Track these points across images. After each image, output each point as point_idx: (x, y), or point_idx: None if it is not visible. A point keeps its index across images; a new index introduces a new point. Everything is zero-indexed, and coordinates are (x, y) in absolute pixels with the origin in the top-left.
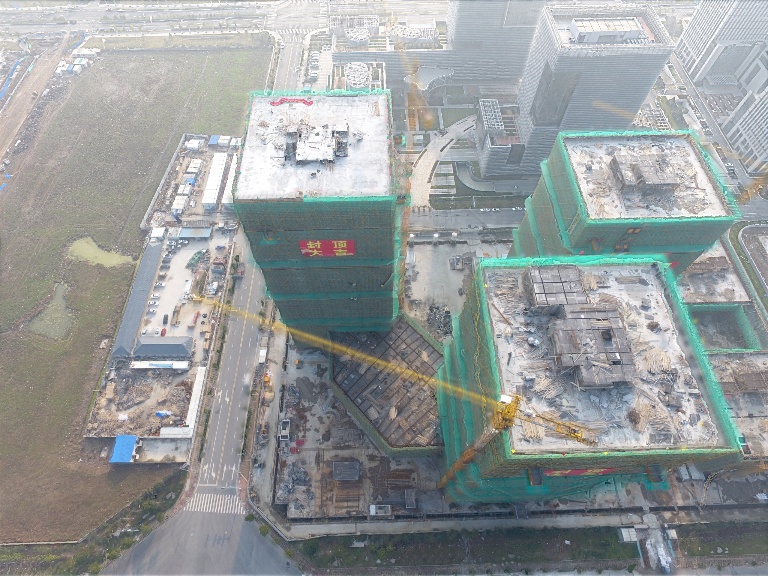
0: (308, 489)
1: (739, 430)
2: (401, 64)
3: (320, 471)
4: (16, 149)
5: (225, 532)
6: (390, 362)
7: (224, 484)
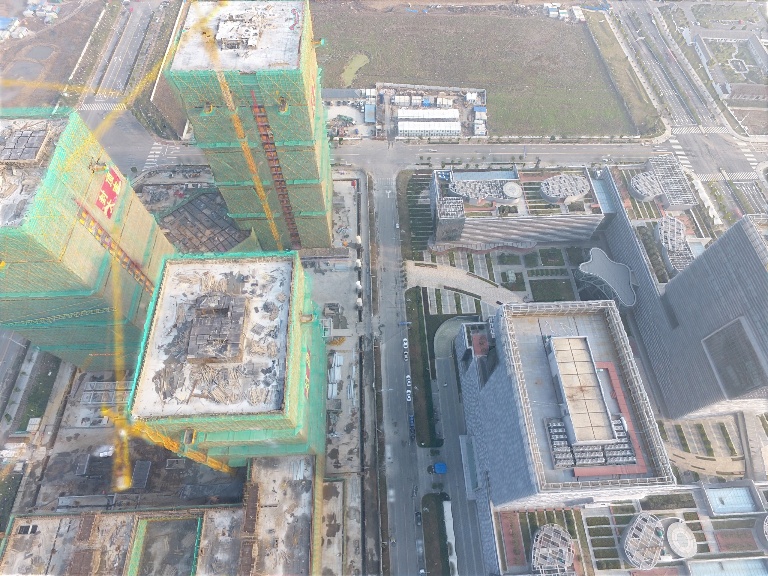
0: (148, 203)
1: (44, 530)
2: (624, 244)
3: (158, 209)
4: (452, 7)
5: (135, 163)
6: (209, 229)
7: (164, 158)
